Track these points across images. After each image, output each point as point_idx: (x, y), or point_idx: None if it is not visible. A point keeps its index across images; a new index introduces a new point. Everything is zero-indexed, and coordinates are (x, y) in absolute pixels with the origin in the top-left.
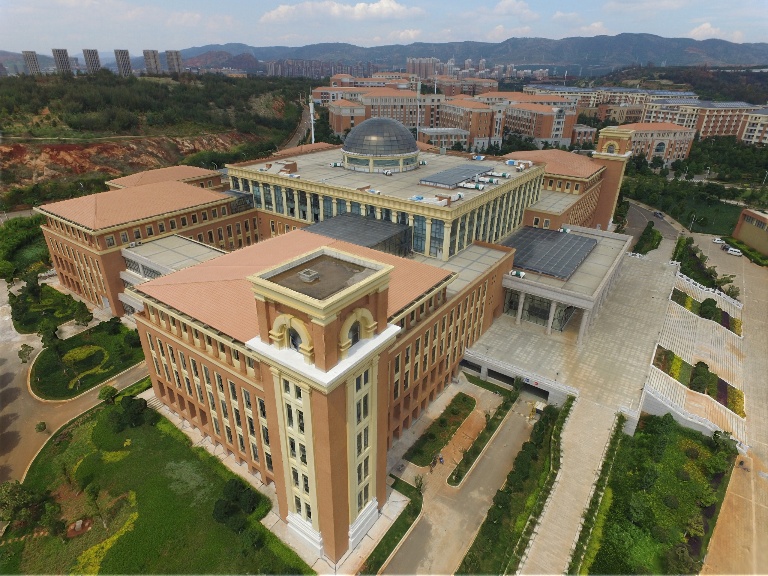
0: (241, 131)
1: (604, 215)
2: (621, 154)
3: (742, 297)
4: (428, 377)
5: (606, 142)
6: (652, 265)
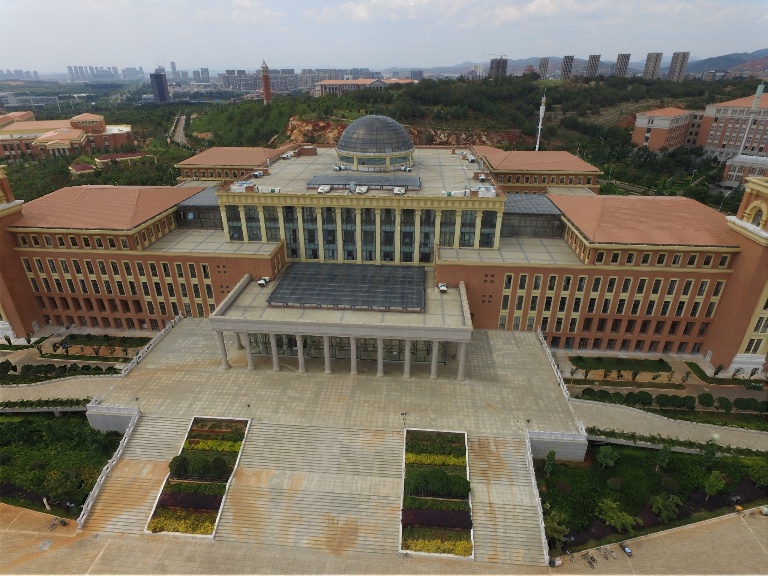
0: (523, 132)
1: (720, 338)
2: (766, 231)
3: (622, 573)
4: (116, 302)
5: (752, 202)
6: (546, 409)
